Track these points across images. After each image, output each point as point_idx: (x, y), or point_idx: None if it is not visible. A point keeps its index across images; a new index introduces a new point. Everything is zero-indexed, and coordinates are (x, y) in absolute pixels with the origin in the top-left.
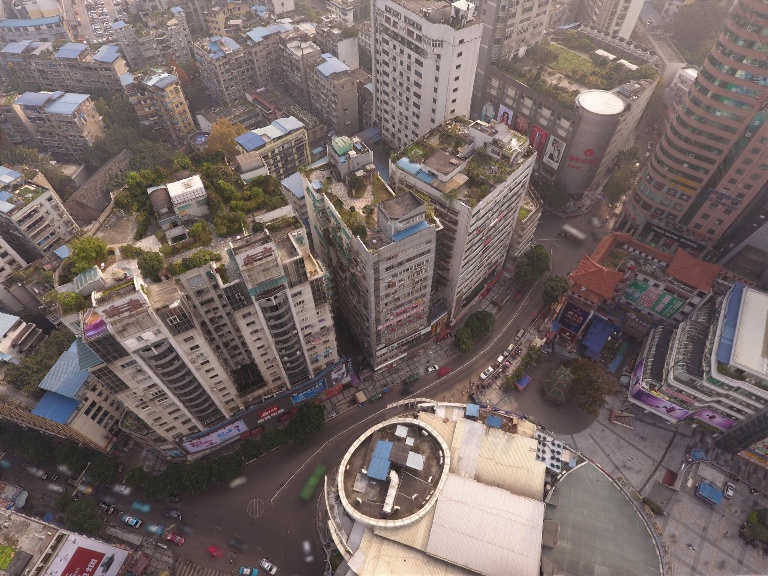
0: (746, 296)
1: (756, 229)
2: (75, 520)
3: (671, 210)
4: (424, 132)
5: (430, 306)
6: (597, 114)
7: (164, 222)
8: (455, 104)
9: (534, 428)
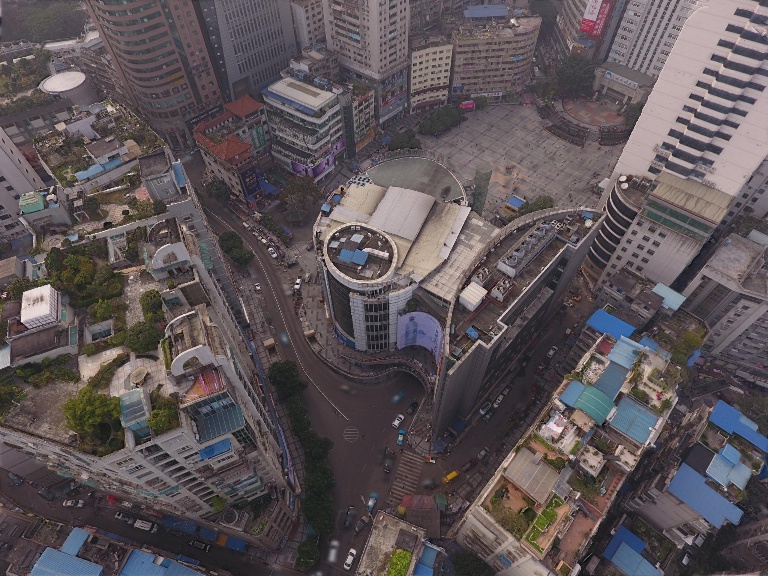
0: (275, 89)
1: (226, 71)
2: None
3: (187, 101)
4: (4, 197)
5: None
6: (77, 87)
7: (73, 341)
8: (6, 144)
9: None
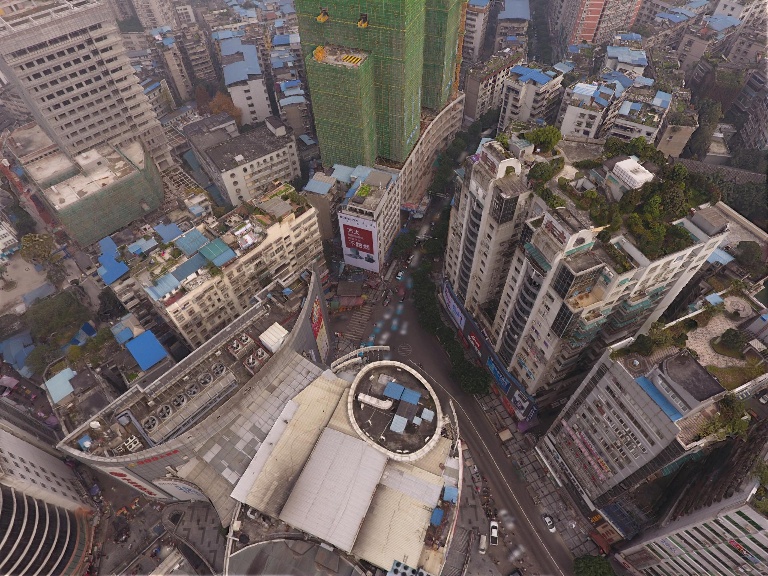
0: None
1: None
2: (399, 239)
3: None
4: None
5: (611, 492)
6: None
7: (593, 173)
8: None
9: (433, 573)
